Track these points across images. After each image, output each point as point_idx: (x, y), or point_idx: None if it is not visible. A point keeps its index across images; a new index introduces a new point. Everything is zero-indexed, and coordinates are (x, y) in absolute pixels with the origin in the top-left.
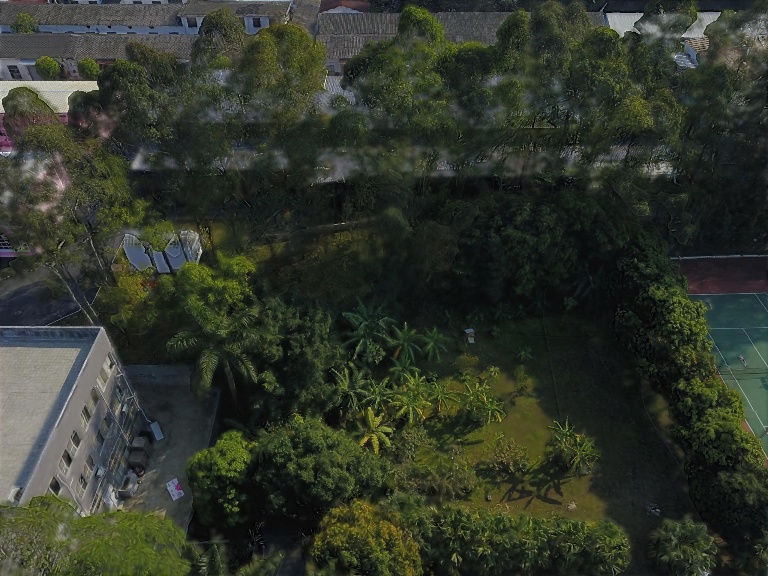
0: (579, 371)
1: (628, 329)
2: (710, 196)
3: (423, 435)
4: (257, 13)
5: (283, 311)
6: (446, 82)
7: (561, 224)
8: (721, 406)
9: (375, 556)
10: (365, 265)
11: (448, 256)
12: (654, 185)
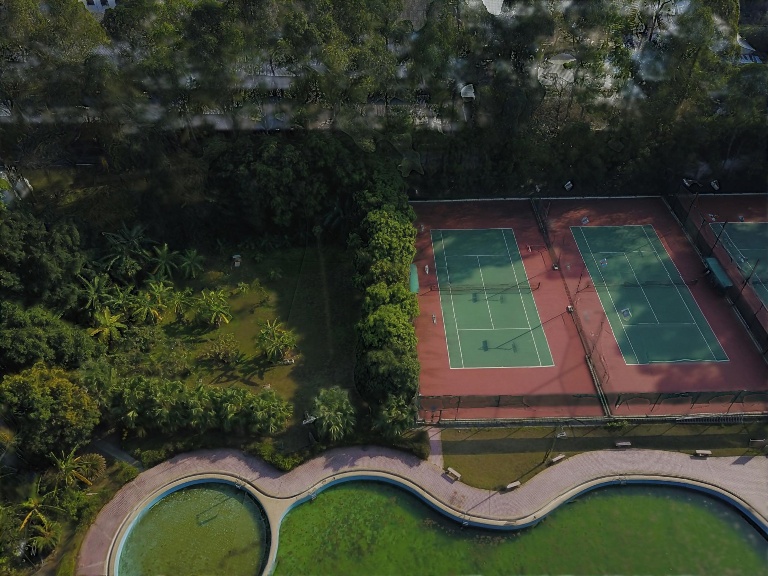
0: (320, 288)
1: (352, 249)
2: (465, 143)
3: (157, 332)
4: None
5: (32, 224)
6: (181, 32)
7: (307, 161)
8: (393, 303)
9: (31, 396)
10: (124, 192)
11: (194, 184)
12: (419, 134)
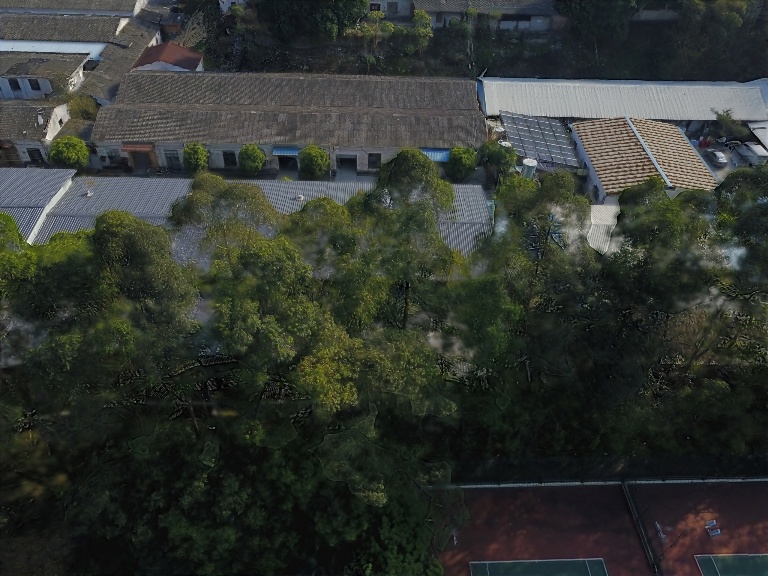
0: None
1: None
2: (527, 415)
3: None
4: (34, 73)
5: None
6: (6, 321)
7: (262, 502)
8: None
9: None
10: None
11: None
12: (451, 393)
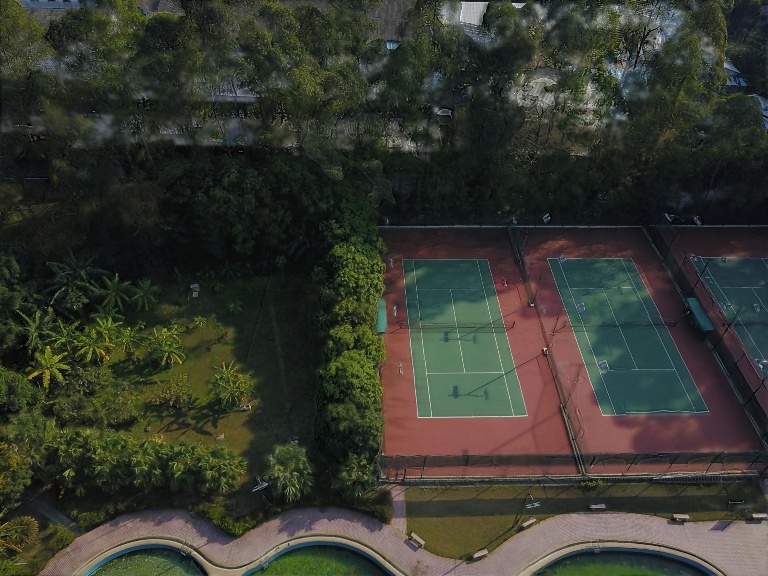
0: (282, 323)
1: (318, 283)
2: (440, 168)
3: (103, 373)
4: None
5: None
6: (133, 48)
7: (271, 187)
8: (357, 349)
9: None
10: (71, 218)
11: (147, 212)
12: (392, 157)
